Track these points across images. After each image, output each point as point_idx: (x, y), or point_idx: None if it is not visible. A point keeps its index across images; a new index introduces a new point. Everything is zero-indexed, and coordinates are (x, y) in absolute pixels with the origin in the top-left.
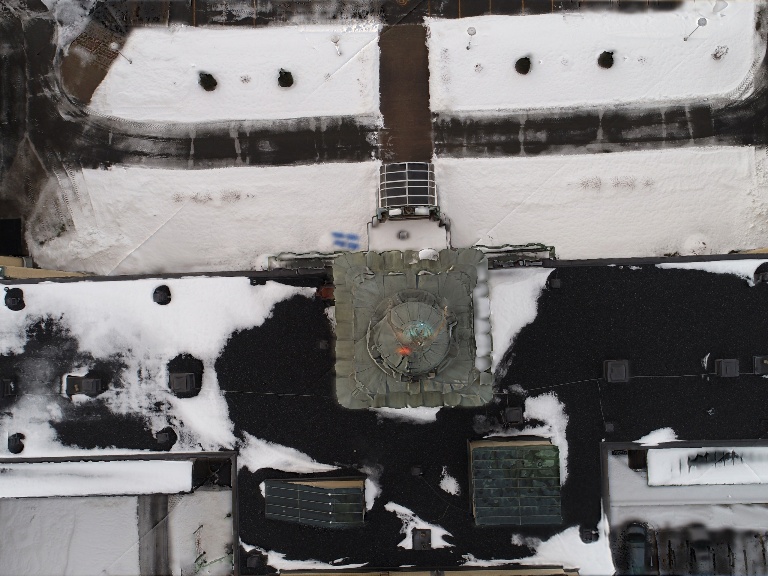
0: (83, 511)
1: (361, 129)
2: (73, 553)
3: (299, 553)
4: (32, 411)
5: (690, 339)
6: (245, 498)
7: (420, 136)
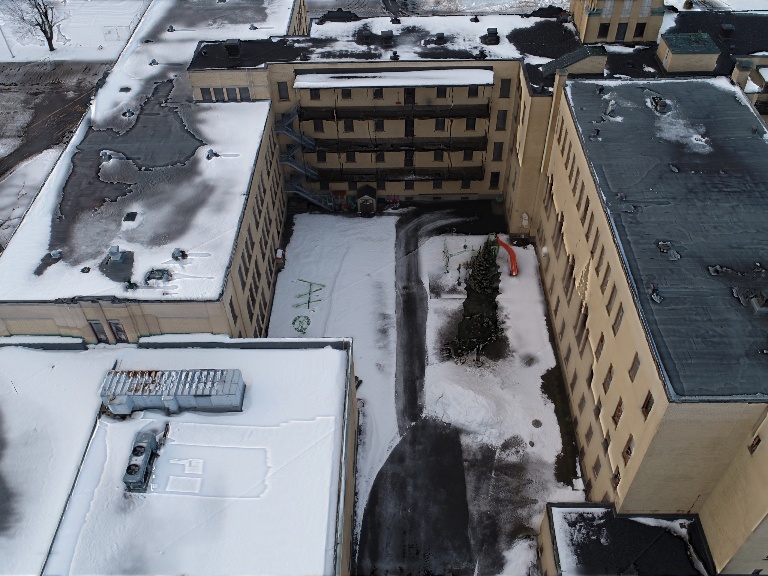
0: (355, 242)
1: None
2: (345, 264)
3: None
4: (404, 49)
5: (761, 30)
6: None
7: None
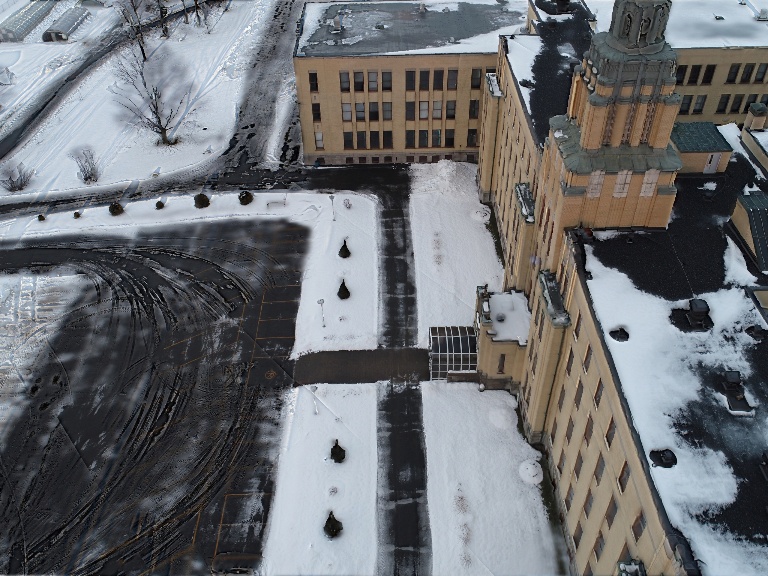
0: None
1: (391, 397)
2: None
3: None
4: None
5: None
6: None
7: (398, 356)
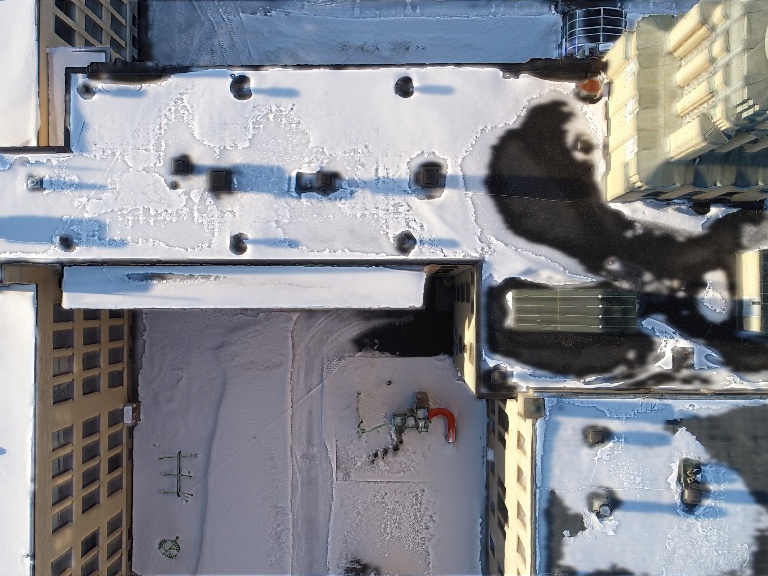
0: (234, 374)
1: None
2: (222, 418)
3: (547, 370)
4: (257, 209)
5: None
6: (490, 309)
7: None
